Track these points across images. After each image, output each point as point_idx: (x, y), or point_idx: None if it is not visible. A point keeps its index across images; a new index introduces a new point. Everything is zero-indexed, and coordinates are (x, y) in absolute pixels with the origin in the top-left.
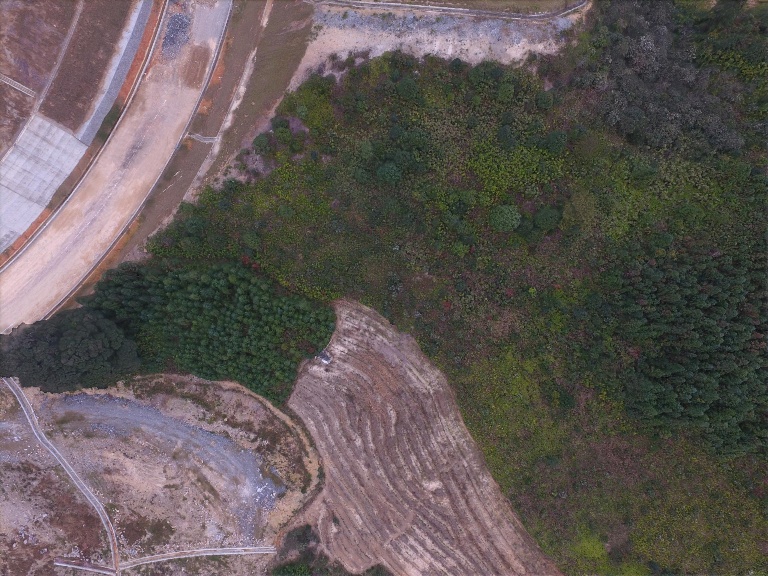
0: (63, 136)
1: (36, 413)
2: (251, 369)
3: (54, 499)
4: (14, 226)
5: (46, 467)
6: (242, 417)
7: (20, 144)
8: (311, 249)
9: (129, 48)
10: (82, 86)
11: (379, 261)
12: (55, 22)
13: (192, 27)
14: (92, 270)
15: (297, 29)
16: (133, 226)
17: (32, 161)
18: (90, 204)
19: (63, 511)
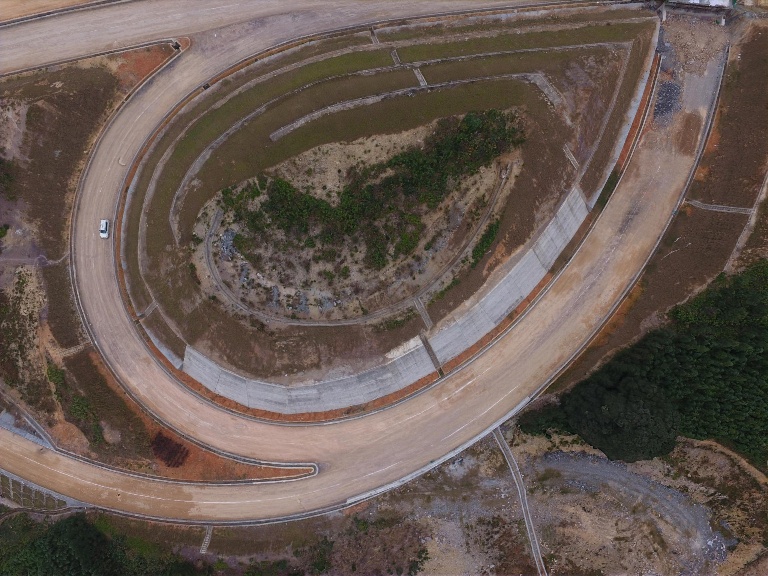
0: (580, 204)
1: (521, 471)
2: (750, 431)
3: (506, 551)
4: (524, 291)
5: (511, 521)
6: (705, 473)
7: (559, 215)
8: None
9: (634, 117)
10: (603, 156)
11: None
12: (604, 97)
13: (683, 95)
14: (595, 334)
15: None
16: (635, 291)
17: (558, 230)
18: (588, 268)
19: (509, 562)
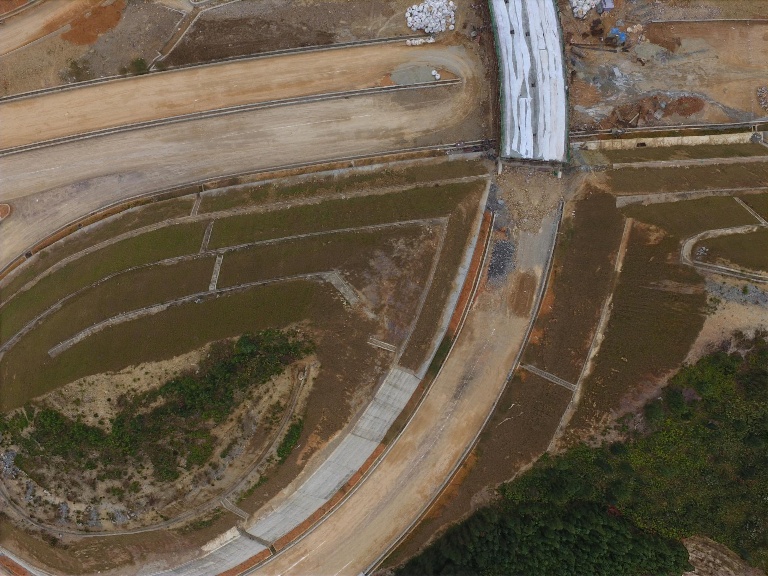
0: (407, 378)
1: None
2: None
3: None
4: (354, 466)
5: None
6: None
7: (378, 397)
8: (673, 495)
9: (463, 283)
10: (428, 329)
11: (739, 504)
12: (418, 278)
13: (517, 254)
14: (430, 505)
15: (678, 292)
16: (470, 460)
17: (382, 407)
18: (423, 437)
19: None
